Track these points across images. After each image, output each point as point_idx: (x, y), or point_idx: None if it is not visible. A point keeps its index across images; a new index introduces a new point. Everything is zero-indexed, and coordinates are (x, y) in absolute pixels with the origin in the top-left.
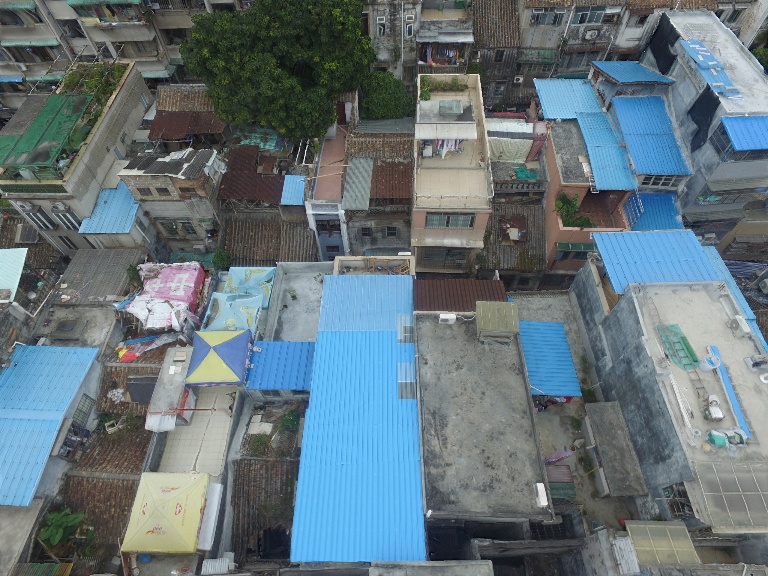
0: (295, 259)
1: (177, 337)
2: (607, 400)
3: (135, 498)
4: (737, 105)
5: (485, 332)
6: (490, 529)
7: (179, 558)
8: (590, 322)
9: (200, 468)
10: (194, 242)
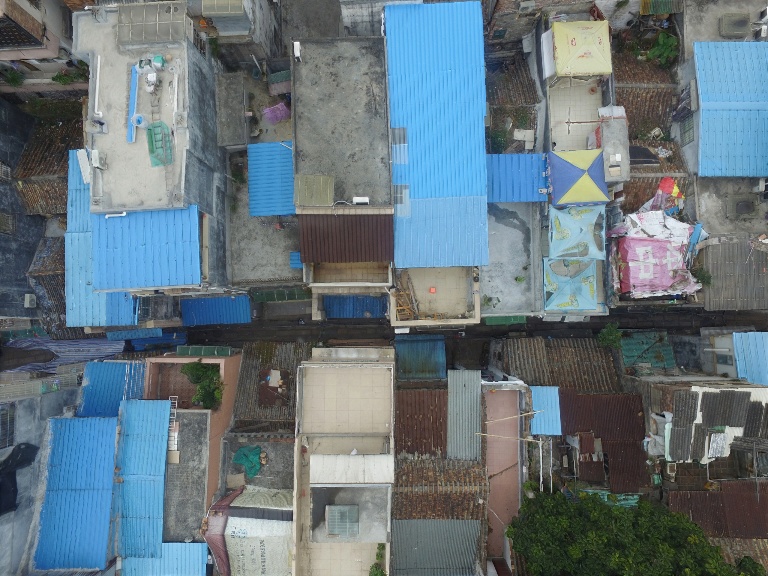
0: (526, 343)
1: None
2: None
3: None
4: None
5: None
6: None
7: None
8: (221, 230)
9: (567, 104)
10: None
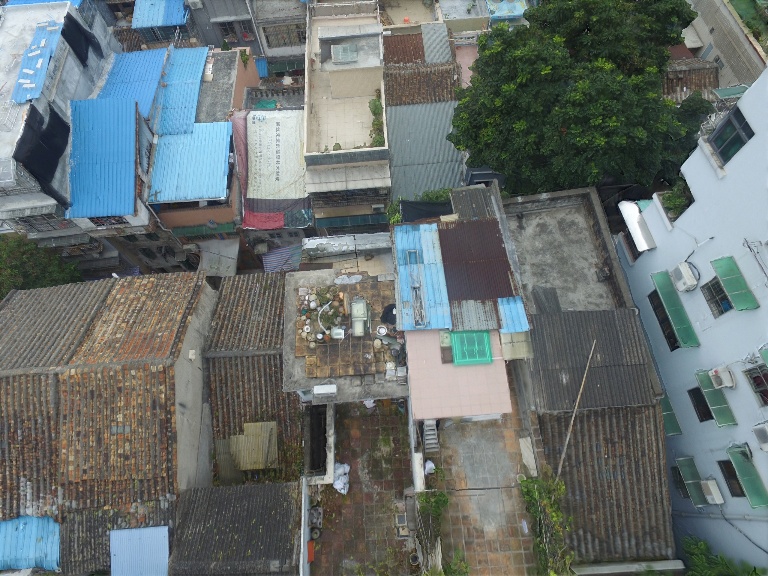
0: None
1: None
2: None
3: None
4: (52, 15)
5: None
6: None
7: None
8: None
9: None
10: None
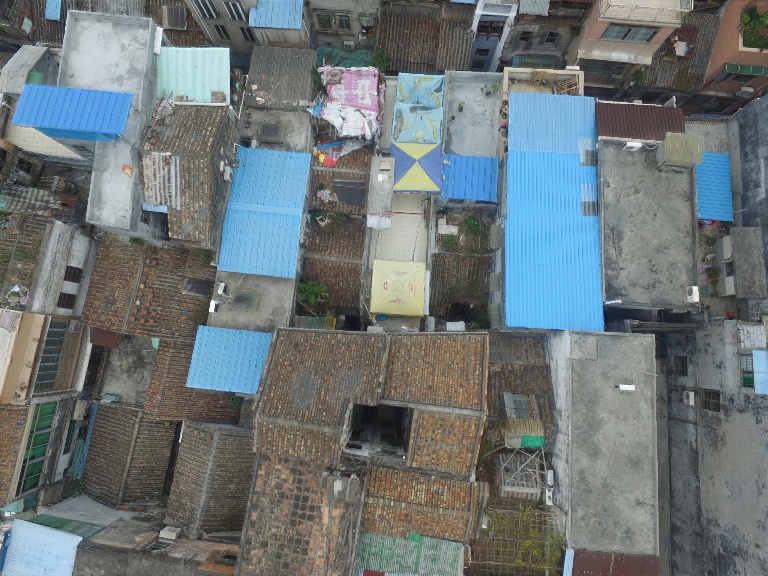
0: (453, 64)
1: (361, 144)
2: (747, 225)
3: (372, 278)
4: None
5: (670, 162)
6: (618, 313)
7: (407, 319)
8: (750, 154)
9: (402, 257)
10: (344, 37)
